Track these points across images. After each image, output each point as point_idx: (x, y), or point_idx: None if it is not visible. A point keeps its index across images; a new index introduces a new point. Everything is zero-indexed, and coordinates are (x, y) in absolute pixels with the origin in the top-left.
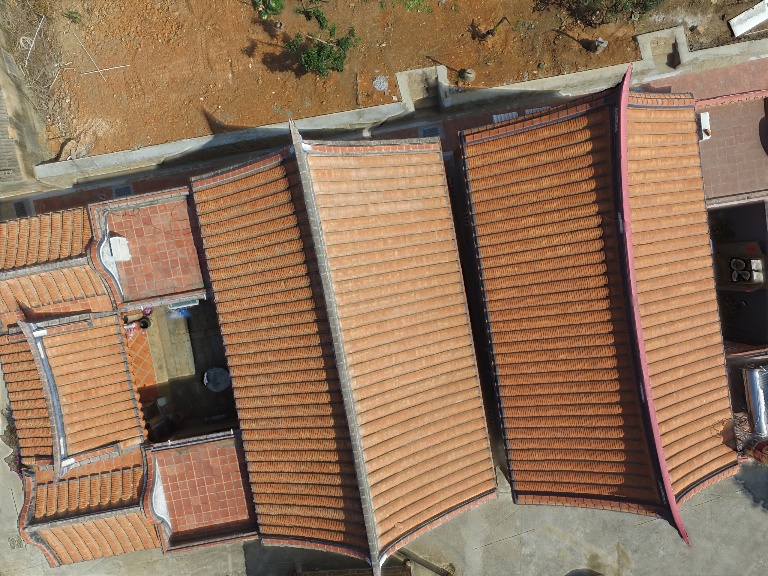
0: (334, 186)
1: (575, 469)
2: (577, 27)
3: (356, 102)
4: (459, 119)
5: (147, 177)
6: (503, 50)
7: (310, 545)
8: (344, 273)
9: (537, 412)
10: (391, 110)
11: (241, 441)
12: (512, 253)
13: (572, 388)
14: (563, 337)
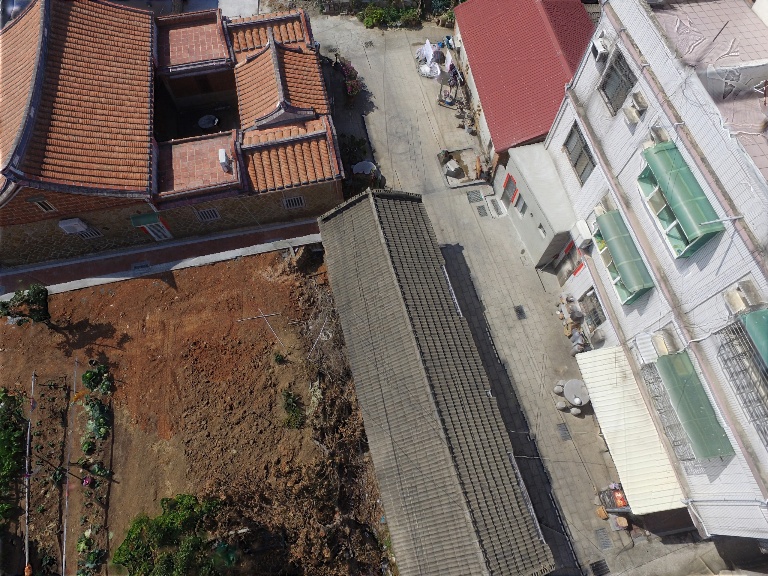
0: None
1: None
2: None
3: None
4: None
5: None
6: None
7: (108, 2)
8: None
9: None
10: (11, 297)
11: None
12: None
13: None
14: None
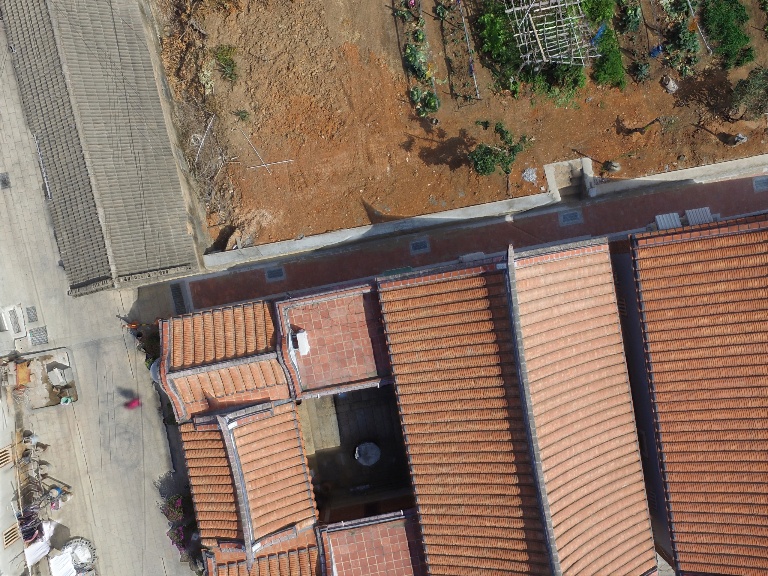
0: (529, 295)
1: (745, 554)
2: (715, 122)
3: (506, 193)
4: (597, 205)
5: (298, 260)
6: (646, 144)
7: None
8: (535, 374)
9: (706, 499)
10: (539, 200)
11: (410, 521)
12: (682, 350)
13: (743, 478)
14: (734, 430)
